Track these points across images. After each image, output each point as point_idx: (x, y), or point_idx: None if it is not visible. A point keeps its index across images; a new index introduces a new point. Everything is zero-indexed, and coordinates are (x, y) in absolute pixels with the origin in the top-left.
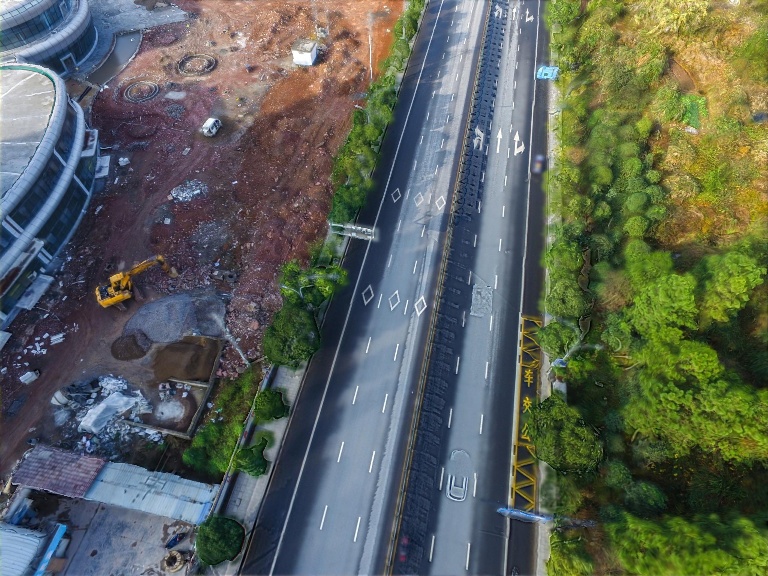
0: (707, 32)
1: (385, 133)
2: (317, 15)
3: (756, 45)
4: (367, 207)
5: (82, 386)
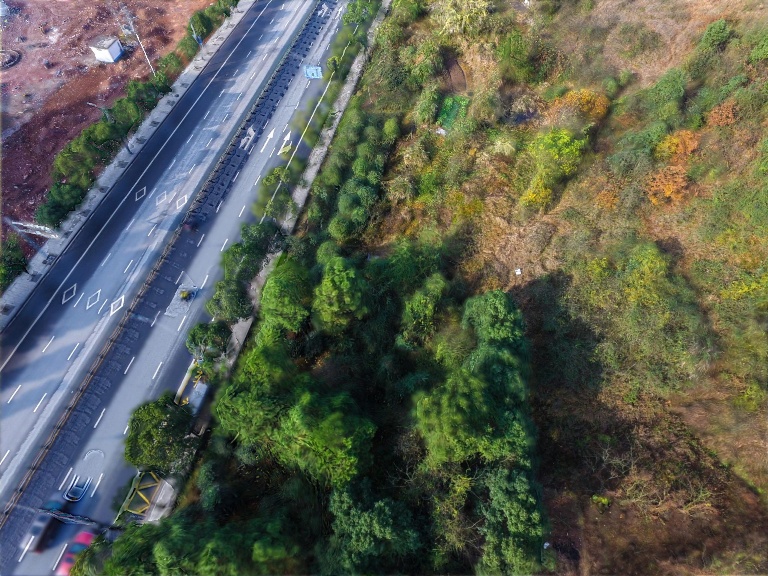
0: (489, 34)
1: (156, 131)
2: (137, 12)
3: (527, 47)
4: (106, 205)
5: None
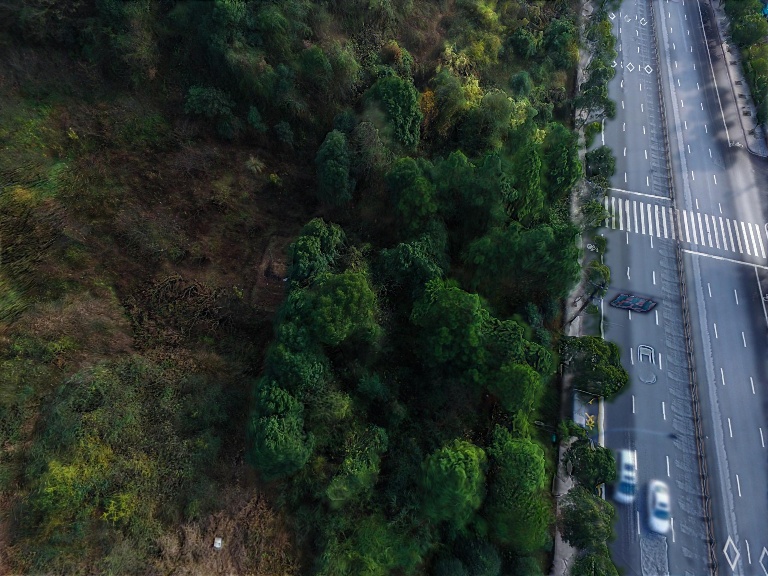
0: None
1: None
2: None
3: None
4: None
5: None
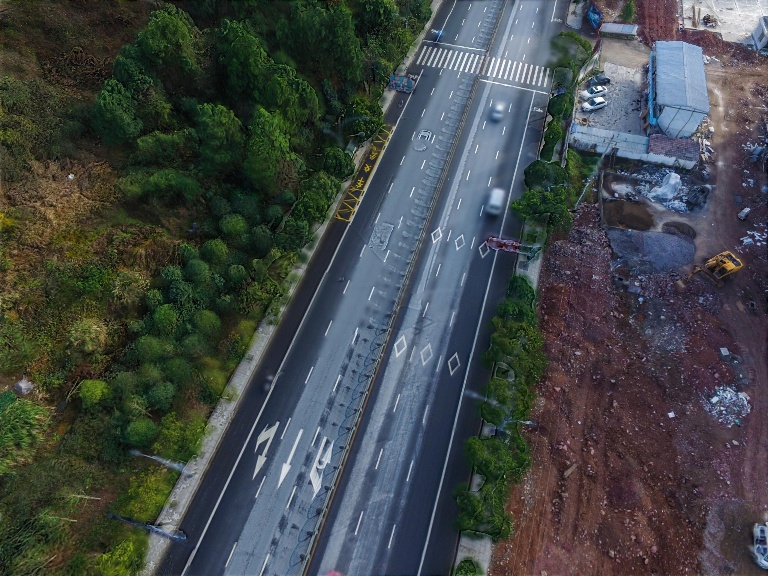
0: None
1: None
2: None
3: None
4: None
5: (697, 201)
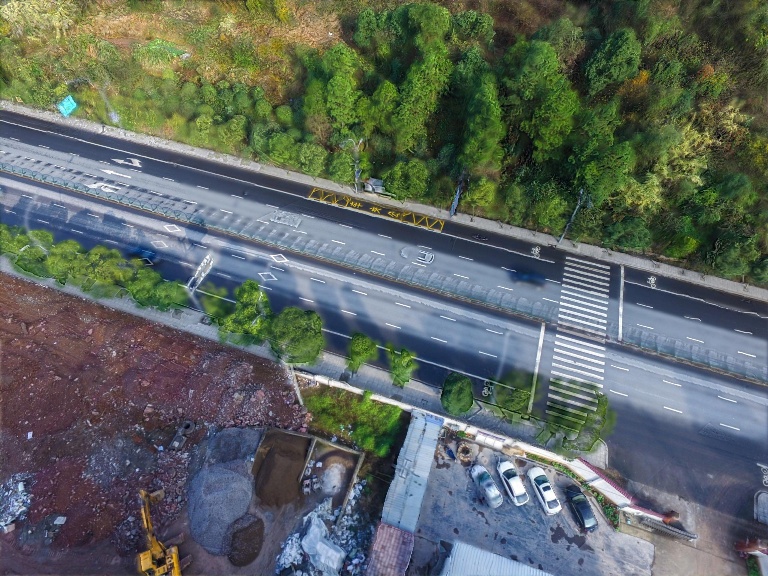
0: (88, 9)
1: None
2: None
3: None
4: None
5: None
